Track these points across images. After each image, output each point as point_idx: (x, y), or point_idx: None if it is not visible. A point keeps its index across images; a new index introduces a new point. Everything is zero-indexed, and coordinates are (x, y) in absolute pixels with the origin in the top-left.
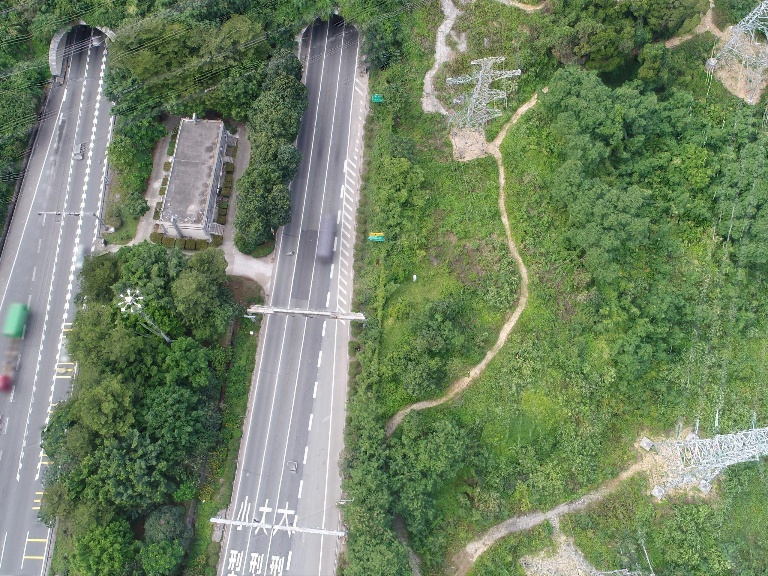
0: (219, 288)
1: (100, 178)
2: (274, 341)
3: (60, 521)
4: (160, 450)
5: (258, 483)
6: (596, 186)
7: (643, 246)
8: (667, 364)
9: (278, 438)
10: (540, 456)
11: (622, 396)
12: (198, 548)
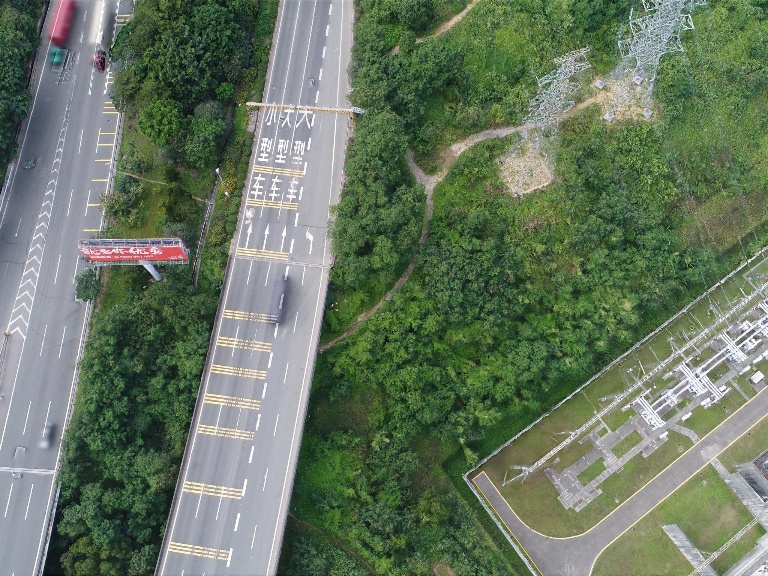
0: None
1: None
2: None
3: (125, 120)
4: (205, 48)
5: (283, 93)
6: None
7: None
8: None
9: (298, 63)
10: (511, 79)
11: None
12: (236, 136)
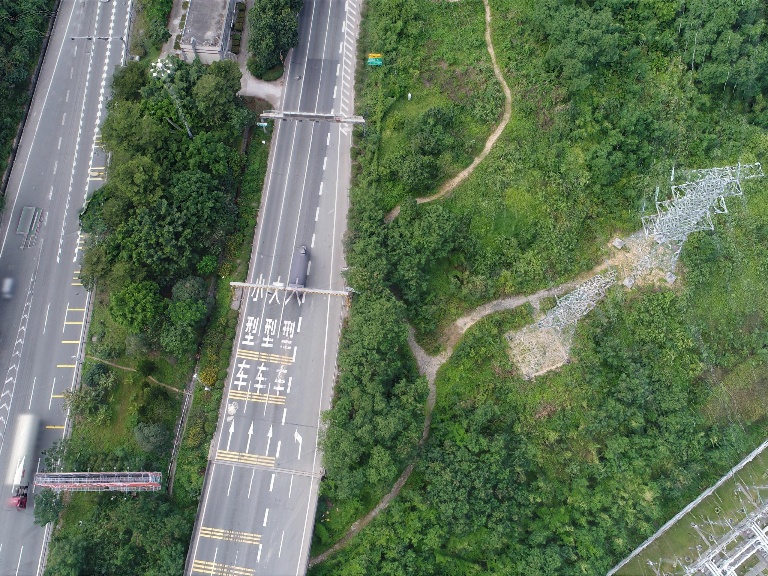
0: (235, 98)
1: (125, 17)
2: (284, 149)
3: (96, 294)
4: (185, 222)
5: (271, 263)
6: (571, 9)
7: (615, 72)
8: (637, 174)
9: (288, 227)
10: (522, 245)
11: (596, 199)
12: (219, 314)
